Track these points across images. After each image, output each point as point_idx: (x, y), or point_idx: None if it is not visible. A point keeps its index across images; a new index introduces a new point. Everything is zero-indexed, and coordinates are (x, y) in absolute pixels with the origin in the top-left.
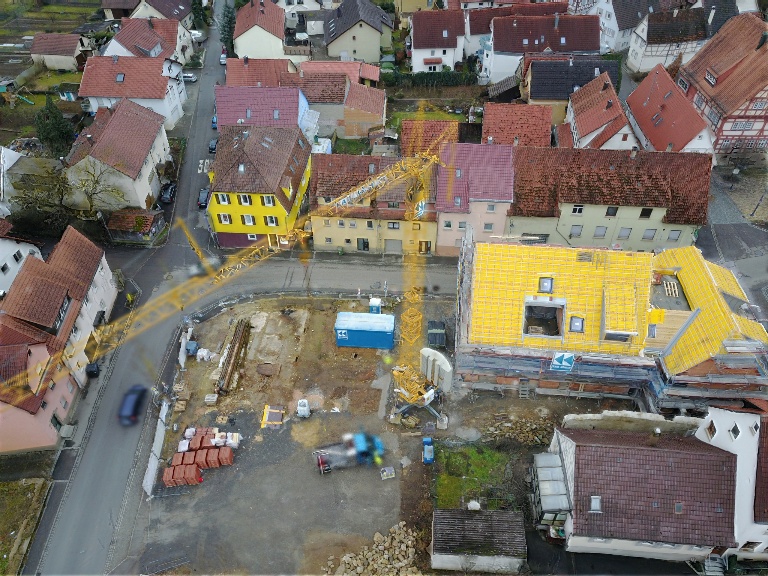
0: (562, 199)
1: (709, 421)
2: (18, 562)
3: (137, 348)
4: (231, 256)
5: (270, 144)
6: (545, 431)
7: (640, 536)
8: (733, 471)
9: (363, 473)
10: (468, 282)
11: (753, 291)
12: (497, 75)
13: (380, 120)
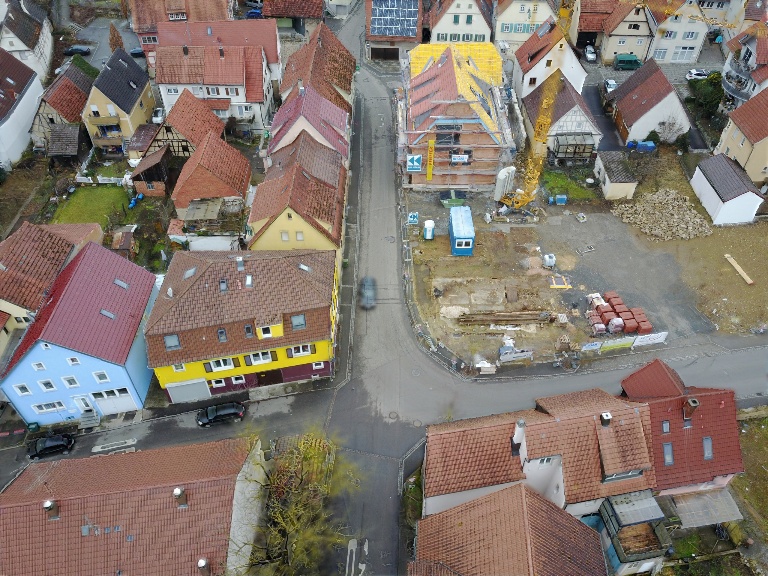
0: (348, 92)
1: (529, 80)
2: (763, 407)
3: (514, 410)
4: (349, 361)
5: (241, 255)
6: (522, 157)
7: (593, 118)
8: (563, 74)
9: (585, 230)
10: (479, 116)
11: (381, 79)
12: (12, 150)
13: (100, 231)
